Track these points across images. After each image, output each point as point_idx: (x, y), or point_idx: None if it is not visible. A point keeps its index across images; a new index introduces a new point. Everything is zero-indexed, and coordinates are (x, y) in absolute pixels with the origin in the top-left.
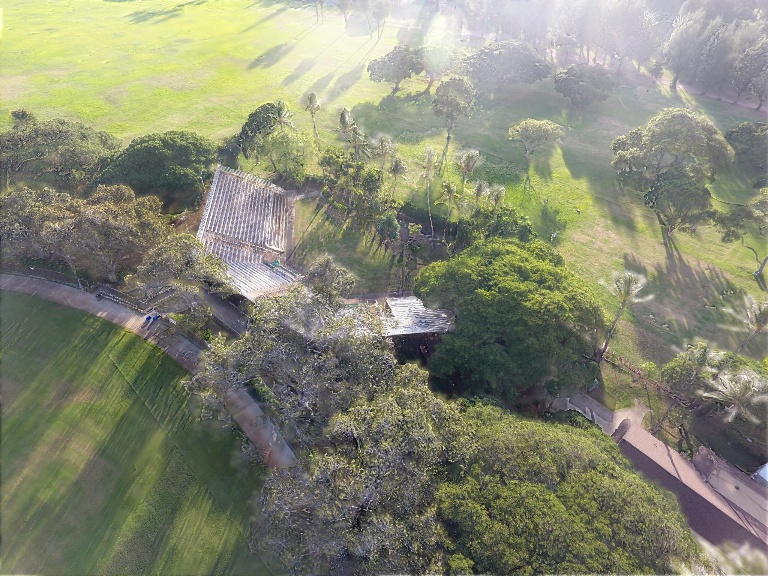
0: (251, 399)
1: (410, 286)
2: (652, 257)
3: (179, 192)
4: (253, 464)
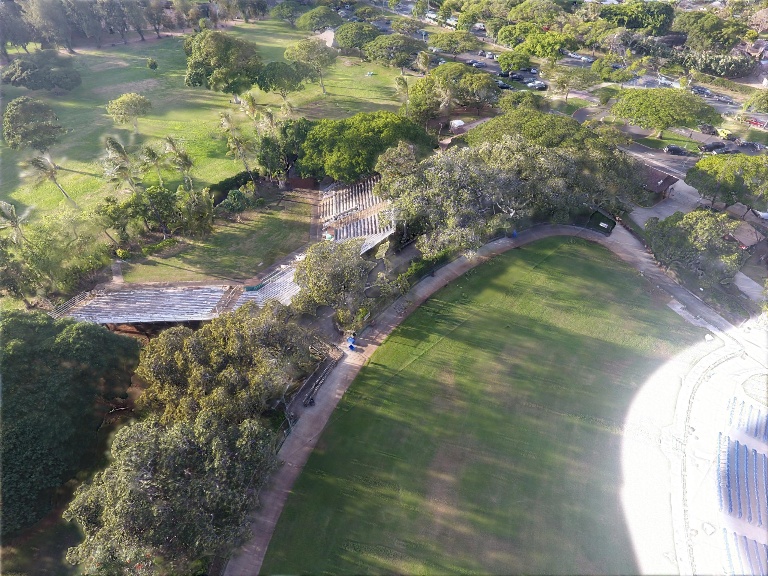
0: (443, 268)
1: (306, 210)
2: (300, 116)
3: (112, 345)
4: (493, 263)
